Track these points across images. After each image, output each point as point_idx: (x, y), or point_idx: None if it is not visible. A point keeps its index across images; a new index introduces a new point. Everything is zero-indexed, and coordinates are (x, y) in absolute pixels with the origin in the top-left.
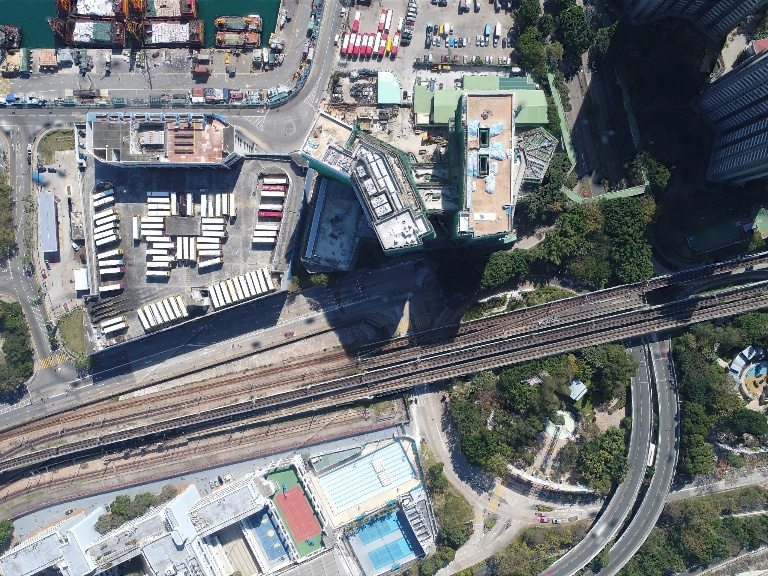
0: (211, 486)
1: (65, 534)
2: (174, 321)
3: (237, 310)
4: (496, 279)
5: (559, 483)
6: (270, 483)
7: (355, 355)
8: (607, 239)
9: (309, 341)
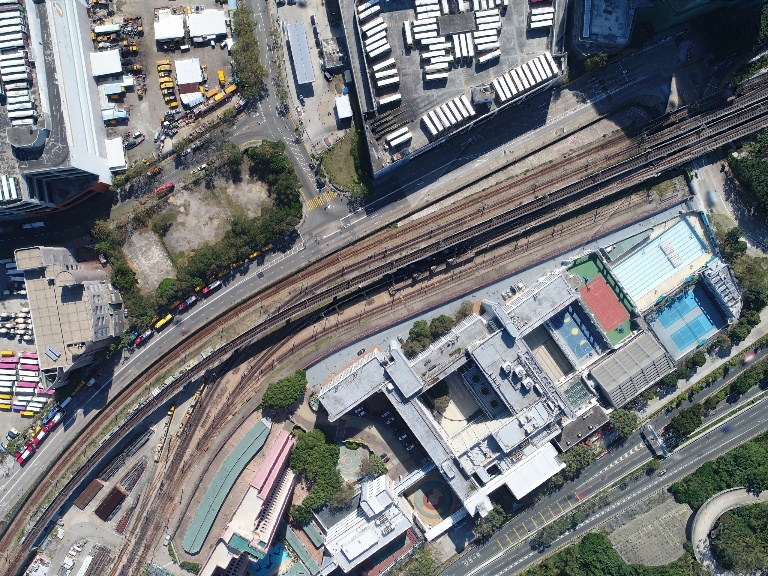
0: (505, 297)
1: None
2: (458, 125)
3: (504, 115)
4: None
5: None
6: None
7: (641, 132)
8: None
9: (583, 133)
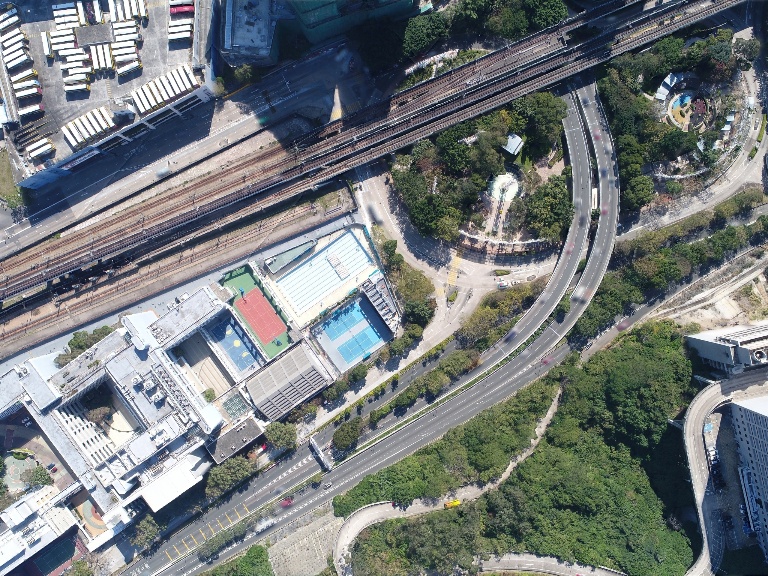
0: (169, 308)
1: (23, 367)
2: (102, 136)
3: (167, 126)
4: (417, 42)
5: (512, 245)
6: (227, 288)
7: (291, 144)
8: None
9: (244, 144)
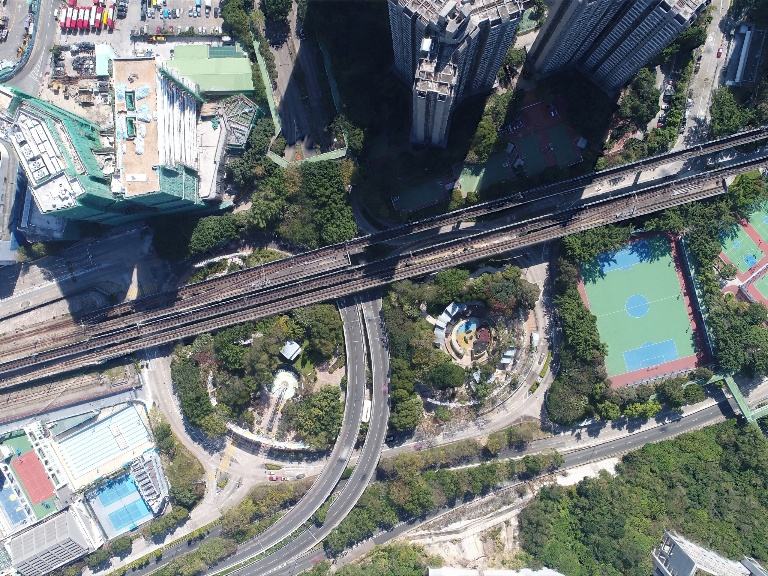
0: None
1: None
2: None
3: None
4: (204, 243)
5: None
6: (4, 448)
7: (78, 321)
8: (309, 201)
9: (42, 310)
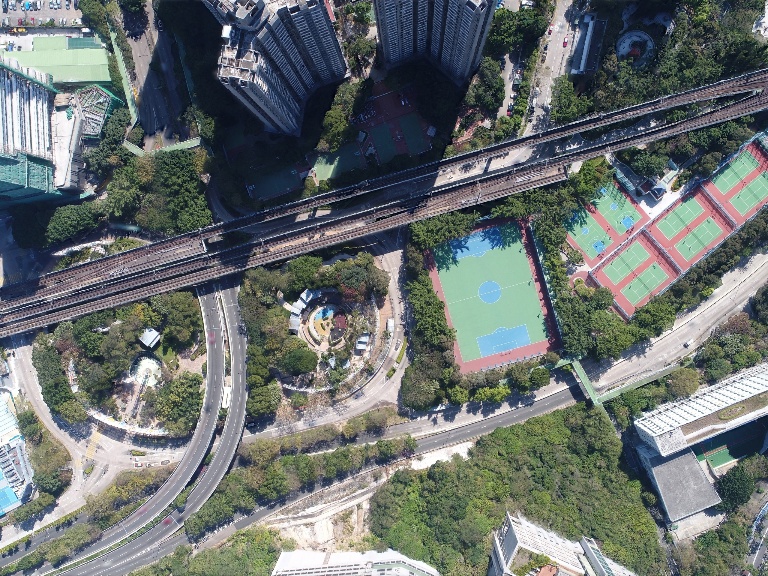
0: None
1: None
2: None
3: None
4: (61, 232)
5: None
6: None
7: None
8: (163, 190)
9: None
